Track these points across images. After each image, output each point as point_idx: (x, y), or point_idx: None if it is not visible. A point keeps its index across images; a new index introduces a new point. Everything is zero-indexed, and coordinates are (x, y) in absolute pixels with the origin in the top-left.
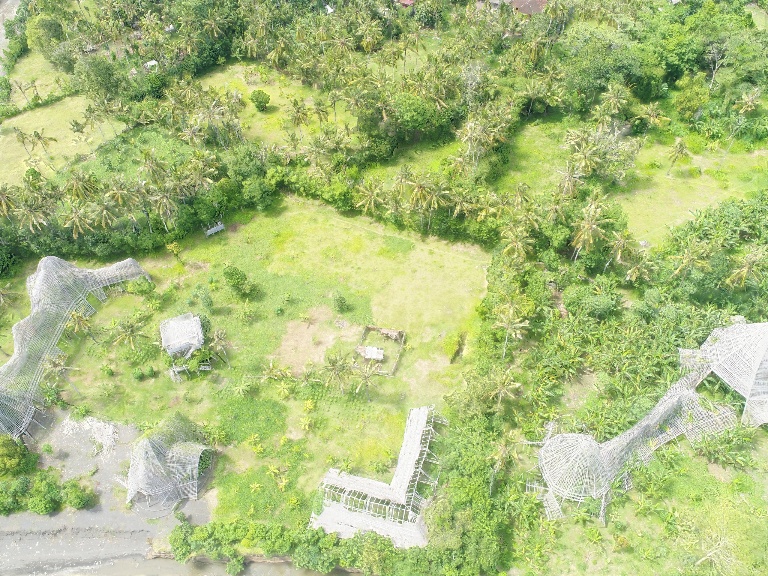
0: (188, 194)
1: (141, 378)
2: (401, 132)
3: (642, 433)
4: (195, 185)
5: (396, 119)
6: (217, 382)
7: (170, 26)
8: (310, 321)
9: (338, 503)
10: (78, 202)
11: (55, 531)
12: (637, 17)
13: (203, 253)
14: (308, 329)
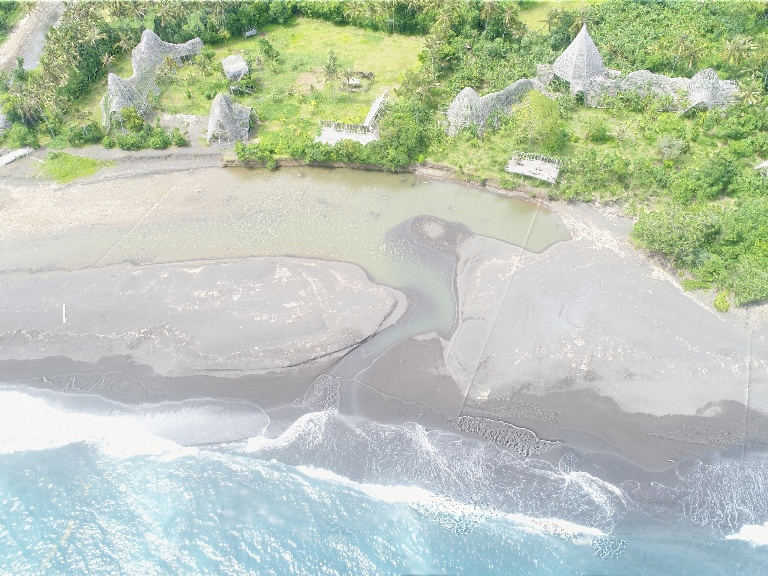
0: (235, 2)
1: (209, 98)
2: None
3: (506, 95)
4: None
5: None
6: (257, 99)
7: None
8: (314, 72)
9: (330, 128)
10: (165, 0)
11: (166, 156)
12: None
13: (243, 45)
14: (313, 76)
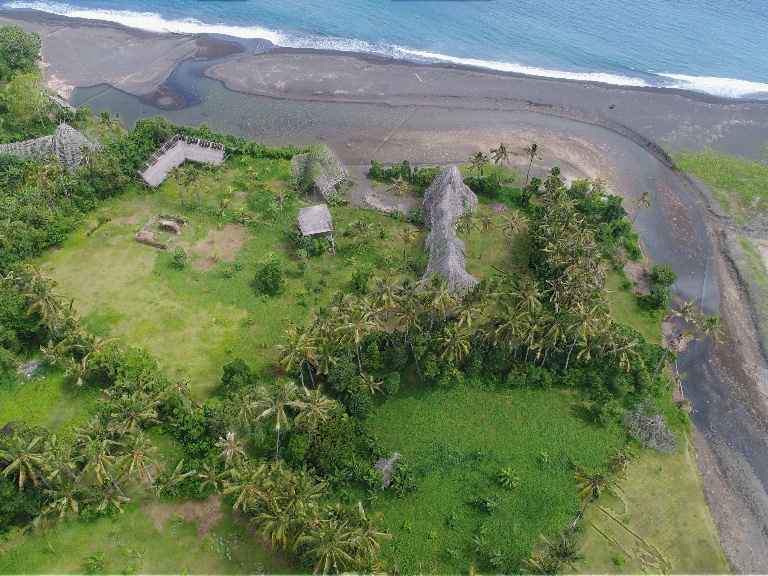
0: None
1: None
2: None
3: None
4: None
5: None
6: (296, 225)
7: None
8: (213, 260)
9: None
10: None
11: None
12: None
13: None
14: None
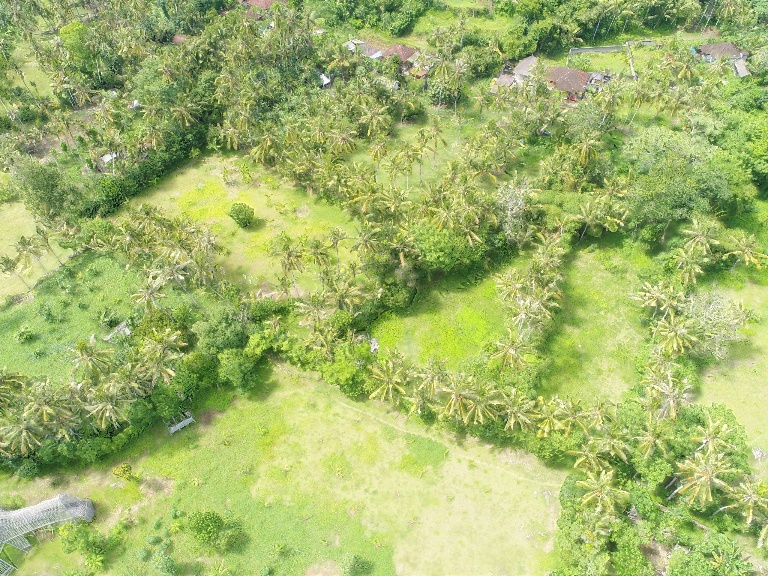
0: (142, 393)
1: None
2: (422, 269)
3: None
4: (152, 379)
5: (416, 256)
6: None
7: (135, 102)
8: None
9: None
10: None
11: None
12: (710, 108)
13: (165, 463)
14: None
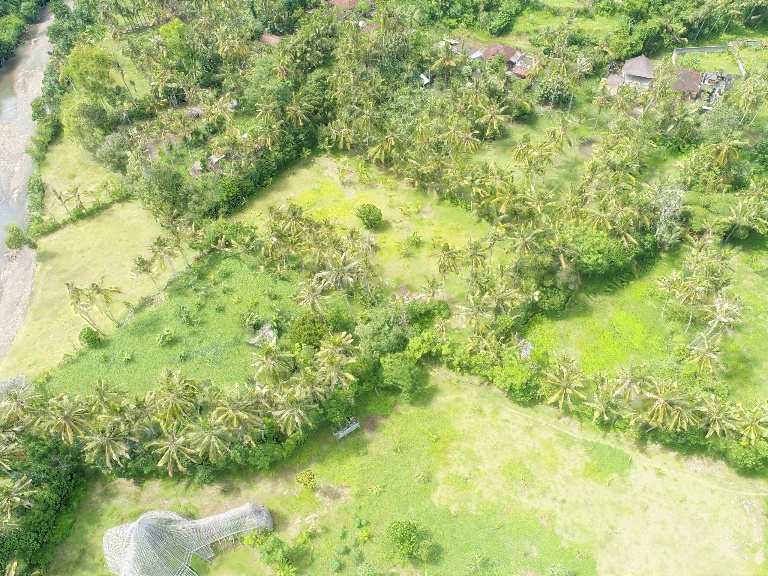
0: (322, 398)
1: None
2: None
3: None
4: (330, 383)
5: (568, 258)
6: None
7: None
8: None
9: None
10: (176, 426)
11: None
12: None
13: (337, 470)
14: None
